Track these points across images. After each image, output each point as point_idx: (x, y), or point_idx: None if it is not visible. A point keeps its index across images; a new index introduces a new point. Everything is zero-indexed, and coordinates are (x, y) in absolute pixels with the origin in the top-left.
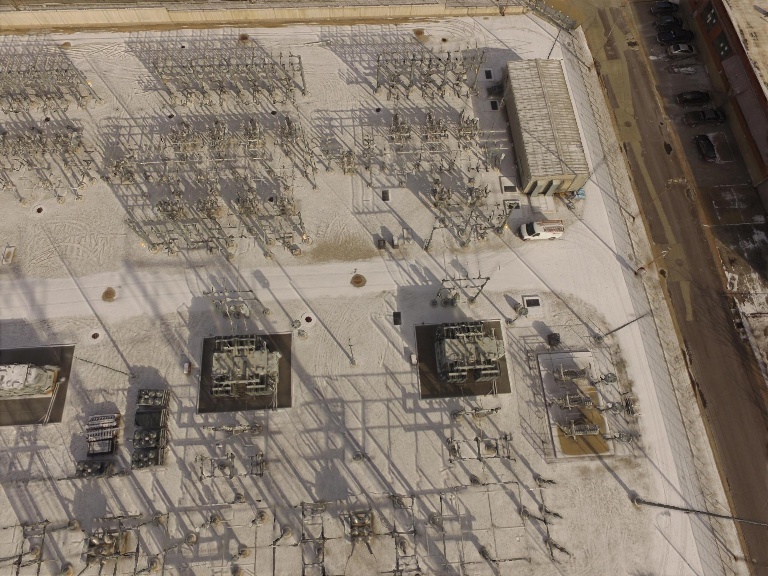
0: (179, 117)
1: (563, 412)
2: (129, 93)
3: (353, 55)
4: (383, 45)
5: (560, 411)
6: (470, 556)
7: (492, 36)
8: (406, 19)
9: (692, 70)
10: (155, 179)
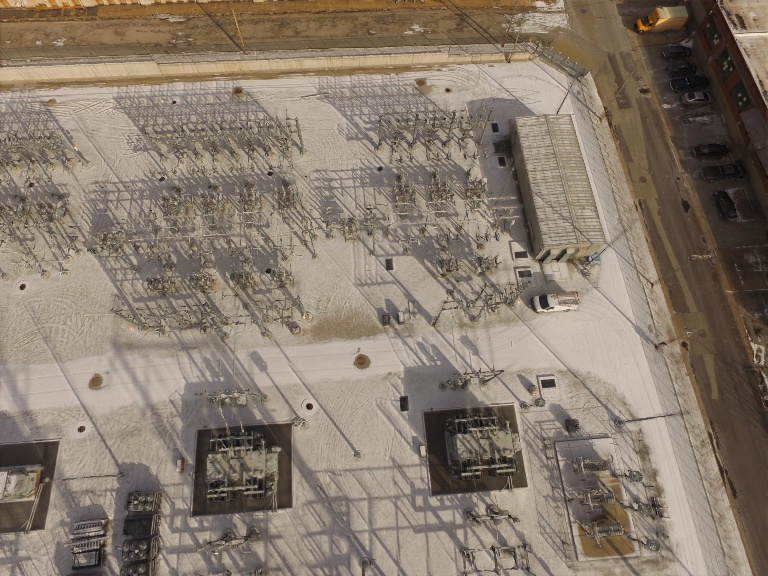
0: (170, 180)
1: (584, 508)
2: (118, 154)
3: (353, 108)
4: (384, 97)
5: (581, 507)
6: None
7: (498, 85)
8: (408, 68)
9: (708, 119)
10: (145, 251)
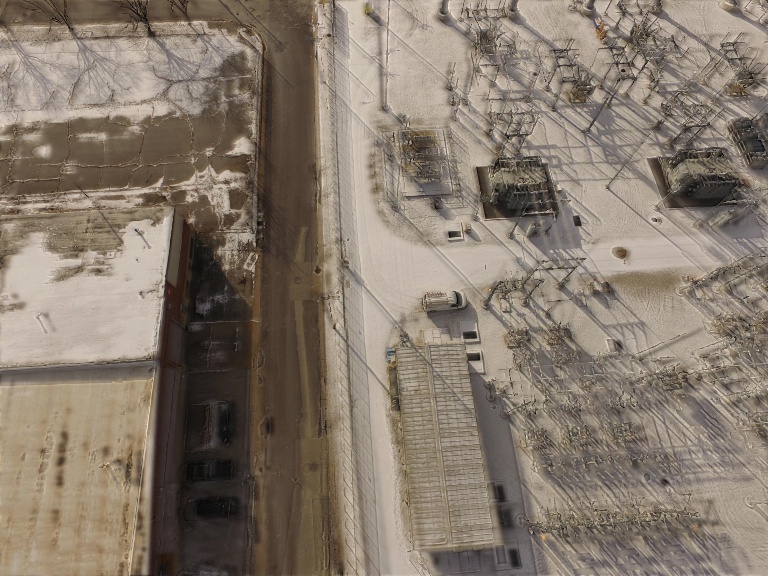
0: None
1: None
2: None
3: None
4: None
5: None
6: (503, 83)
7: None
8: None
9: None
10: None
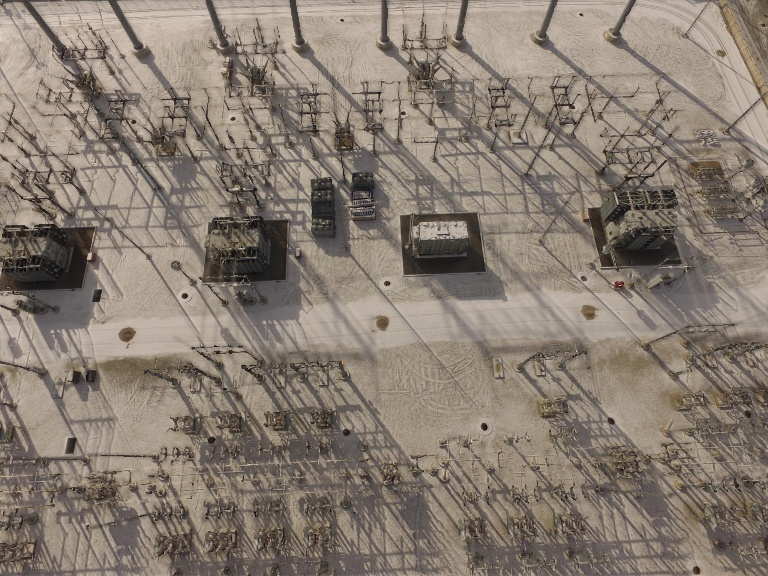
0: None
1: None
2: None
3: None
4: None
5: None
6: (93, 132)
7: None
8: None
9: None
10: None
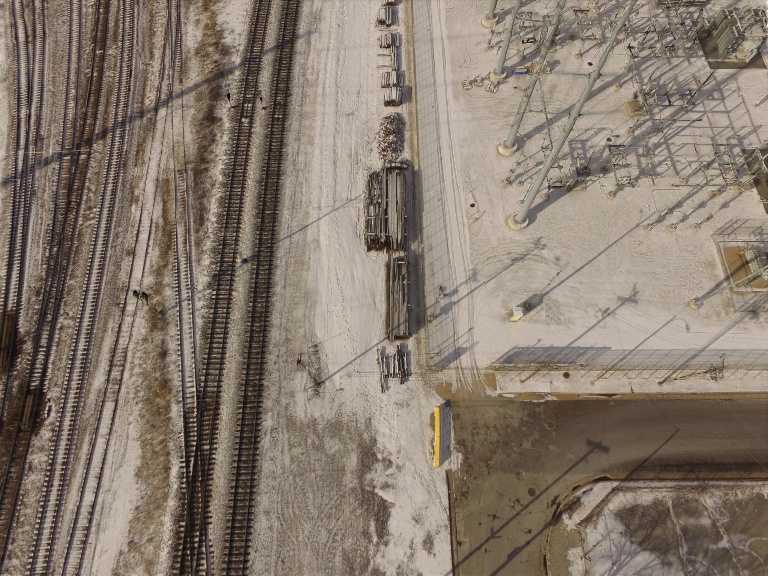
0: None
1: (762, 253)
2: None
3: None
4: None
5: (762, 250)
6: None
7: None
8: None
9: None
10: None
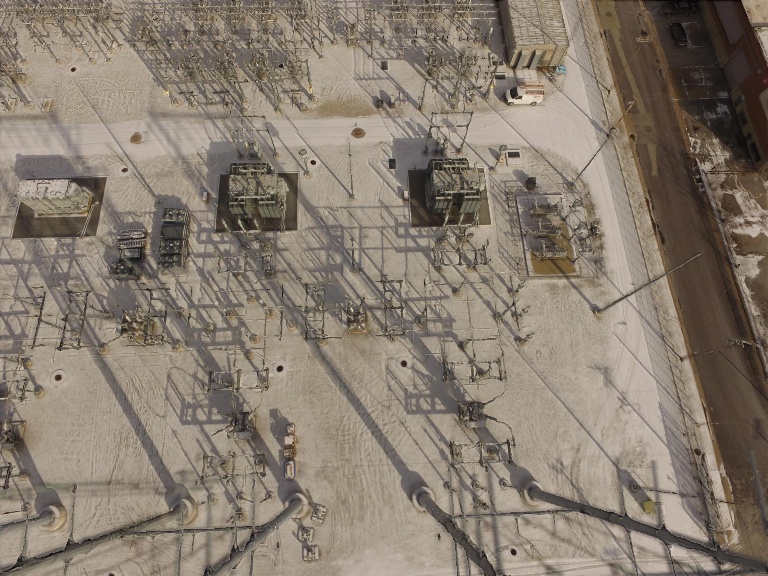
0: None
1: (536, 240)
2: None
3: None
4: None
5: (534, 240)
6: (450, 349)
7: None
8: None
9: None
10: (177, 45)
